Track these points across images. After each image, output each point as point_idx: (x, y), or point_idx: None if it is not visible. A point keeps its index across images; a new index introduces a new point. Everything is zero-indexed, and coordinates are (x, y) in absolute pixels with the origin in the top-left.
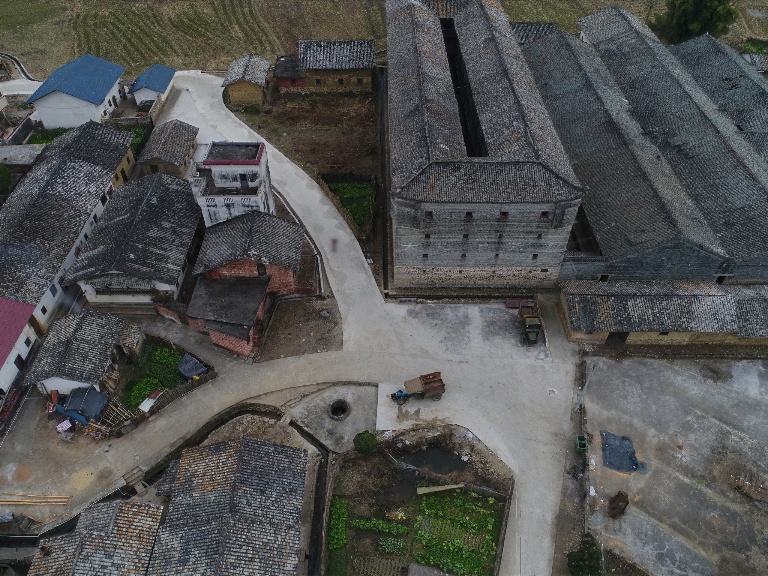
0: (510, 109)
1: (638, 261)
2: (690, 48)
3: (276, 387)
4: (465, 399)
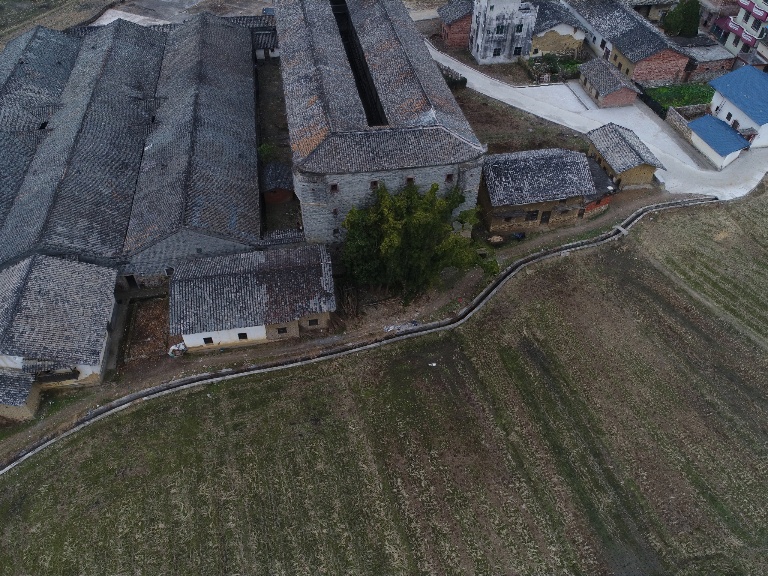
0: (309, 2)
1: None
2: None
3: None
4: None
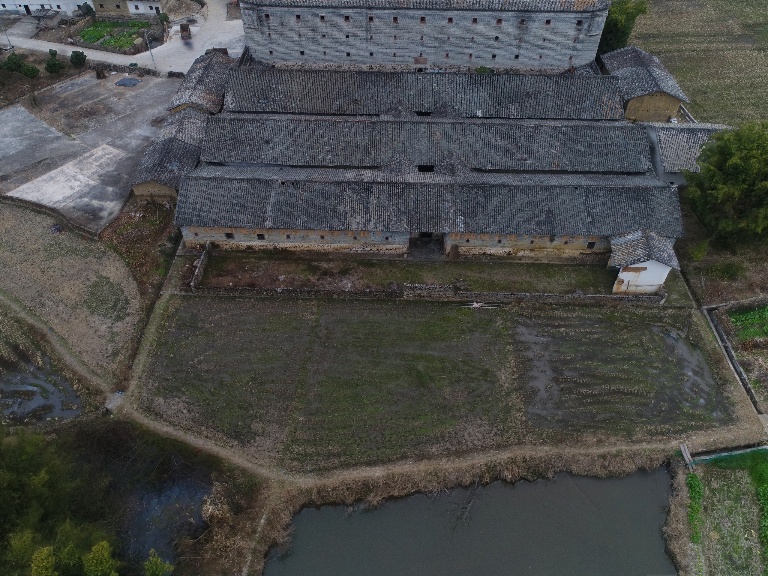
0: None
1: None
2: (641, 180)
3: (210, 8)
4: (179, 45)
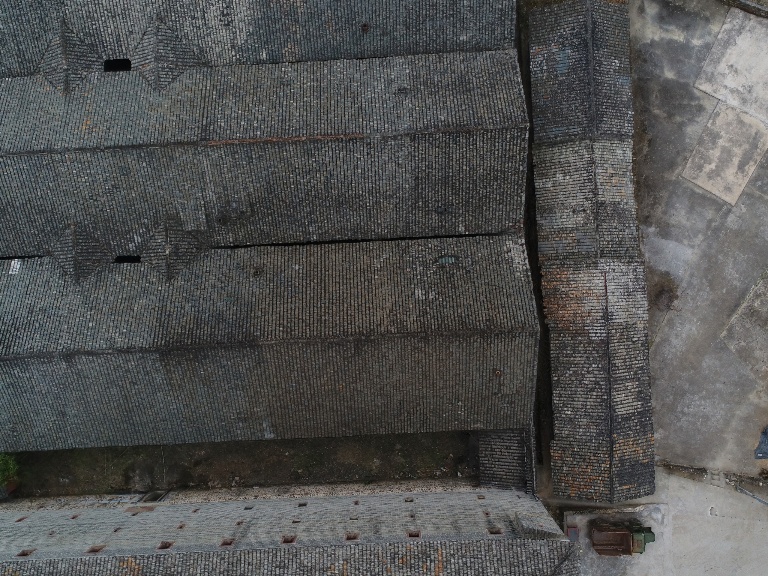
0: None
1: None
2: None
3: None
4: None
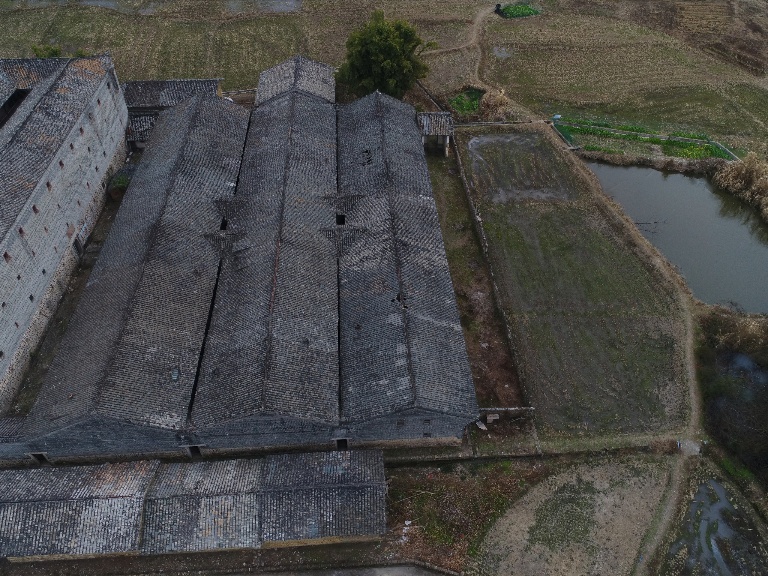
0: None
1: (63, 439)
2: (356, 109)
3: None
4: None
